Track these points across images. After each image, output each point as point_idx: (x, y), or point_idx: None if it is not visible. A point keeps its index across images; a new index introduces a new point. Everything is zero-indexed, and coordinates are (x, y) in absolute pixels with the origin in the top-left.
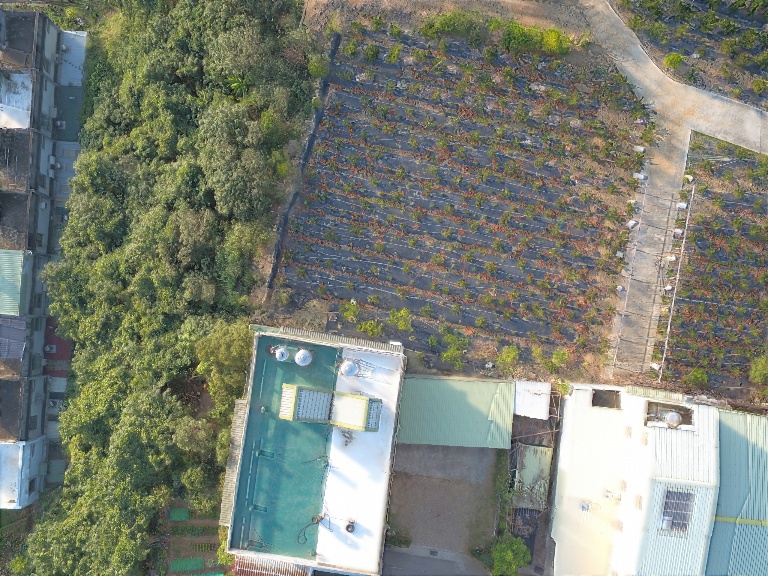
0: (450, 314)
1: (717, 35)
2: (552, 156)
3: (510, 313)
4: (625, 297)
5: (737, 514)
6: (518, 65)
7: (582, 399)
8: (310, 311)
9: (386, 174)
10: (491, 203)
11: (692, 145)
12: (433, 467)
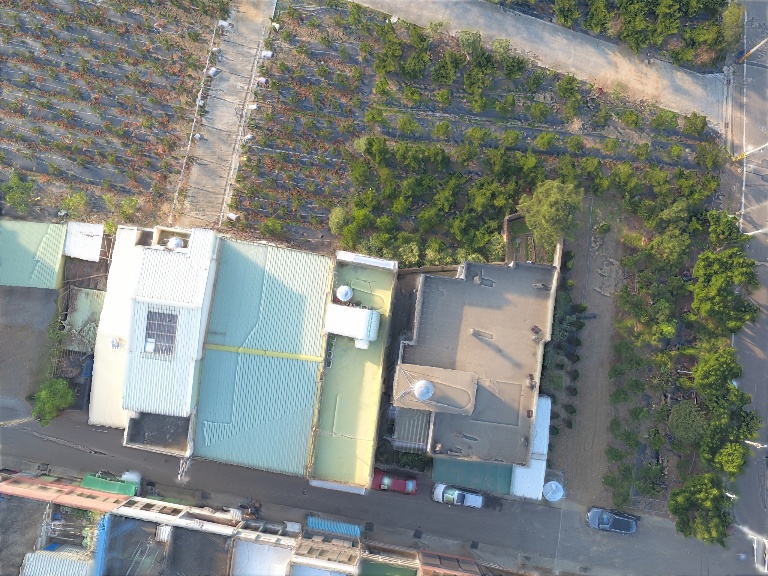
0: (23, 161)
1: None
2: (139, 4)
3: (83, 160)
4: (204, 146)
5: (241, 343)
6: None
7: (125, 238)
8: None
9: None
10: (72, 50)
11: None
12: None
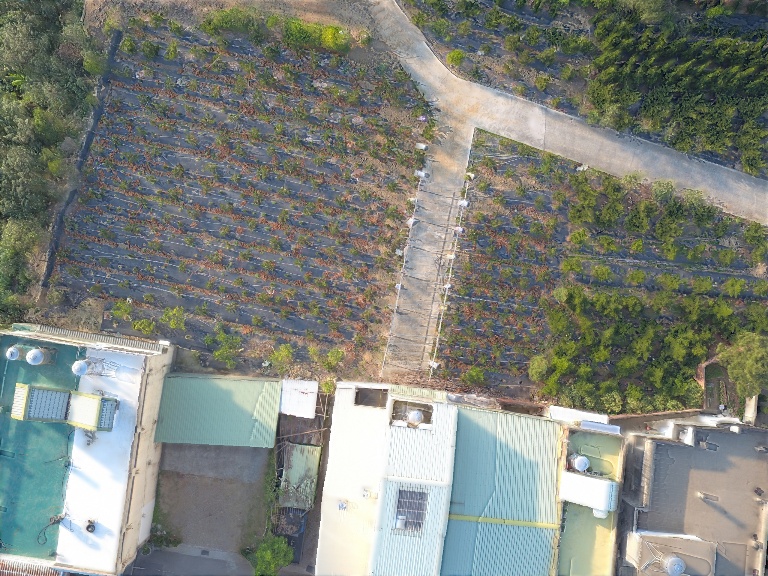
0: (226, 312)
1: (504, 32)
2: (334, 153)
3: (287, 311)
4: (404, 295)
5: (480, 513)
6: (301, 62)
7: (345, 398)
8: (85, 310)
9: (165, 172)
10: (271, 201)
11: (474, 142)
12: (205, 466)
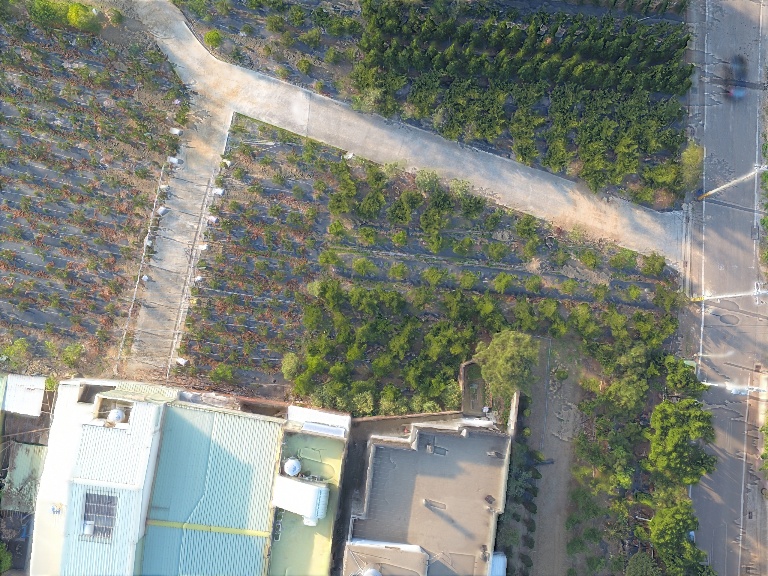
0: None
1: (269, 12)
2: (84, 138)
3: (25, 303)
4: (152, 288)
5: (185, 518)
6: (52, 41)
7: (68, 395)
8: None
9: None
10: (14, 187)
11: (232, 128)
12: None
